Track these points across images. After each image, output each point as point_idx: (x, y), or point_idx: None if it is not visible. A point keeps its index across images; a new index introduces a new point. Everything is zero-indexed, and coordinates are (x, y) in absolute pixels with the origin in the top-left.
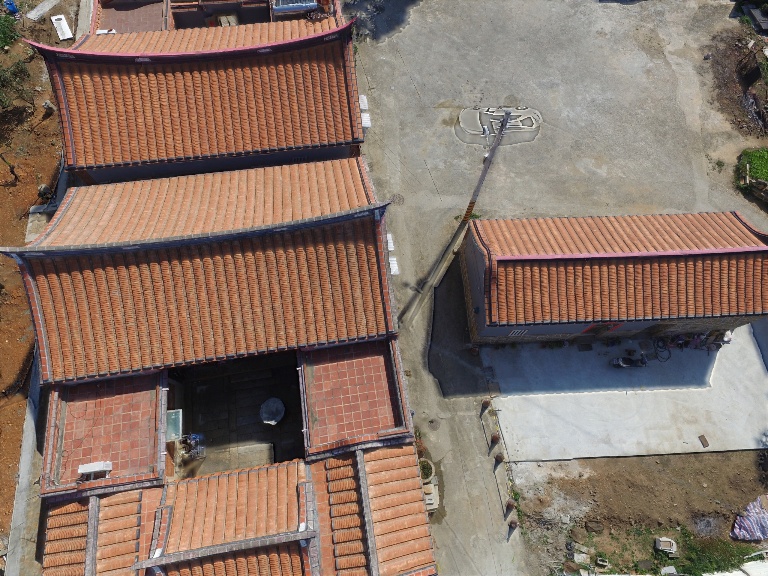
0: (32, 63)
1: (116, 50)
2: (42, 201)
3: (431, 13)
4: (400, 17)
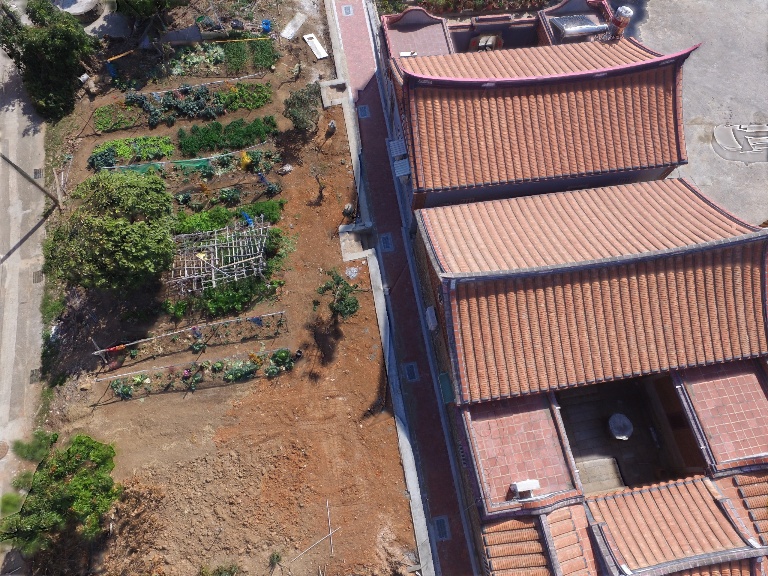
0: (297, 82)
1: (444, 74)
2: (348, 220)
3: (660, 30)
4: (631, 34)
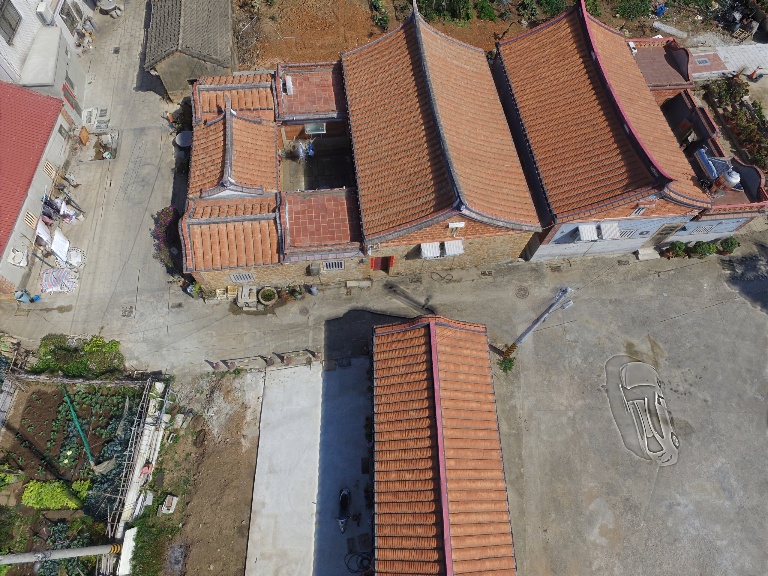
0: None
1: (606, 46)
2: None
3: None
4: None
